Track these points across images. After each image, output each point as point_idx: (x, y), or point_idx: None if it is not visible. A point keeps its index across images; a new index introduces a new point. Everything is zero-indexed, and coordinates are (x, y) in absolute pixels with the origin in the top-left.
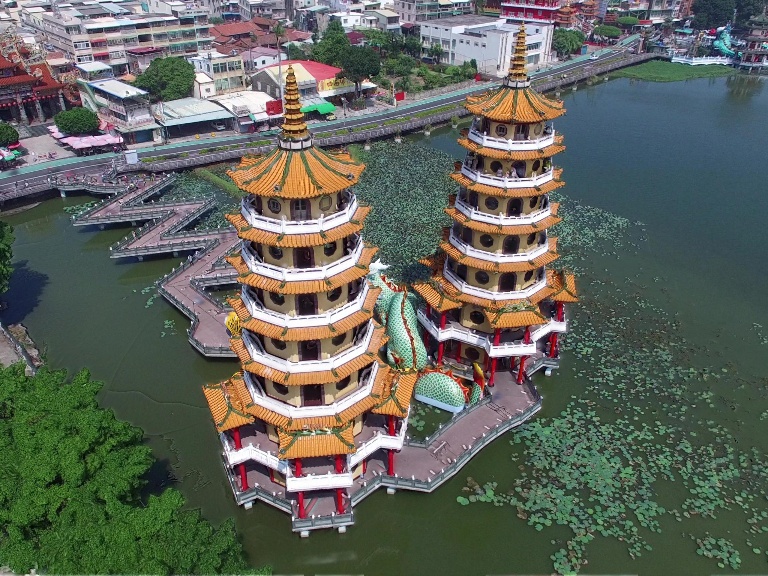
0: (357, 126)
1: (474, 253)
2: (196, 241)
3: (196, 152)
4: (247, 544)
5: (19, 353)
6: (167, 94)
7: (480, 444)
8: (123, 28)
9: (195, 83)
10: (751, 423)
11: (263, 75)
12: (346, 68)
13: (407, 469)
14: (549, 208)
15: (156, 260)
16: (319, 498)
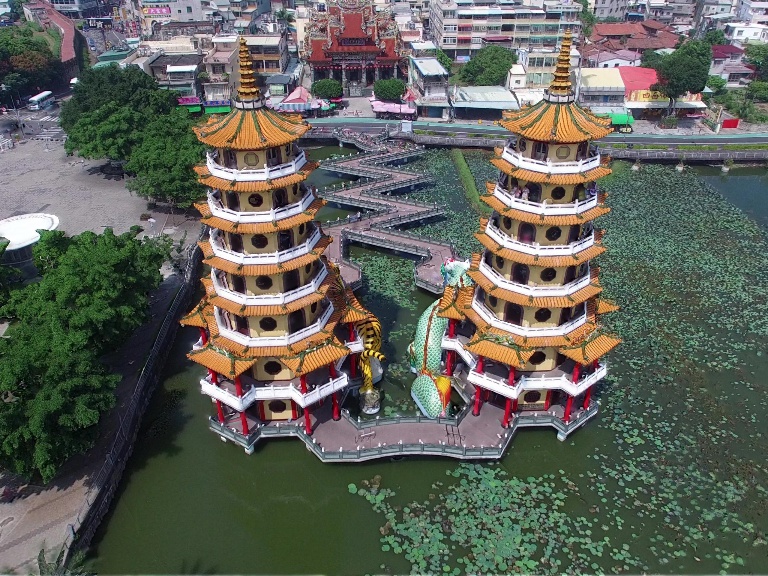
0: (645, 144)
1: (485, 269)
2: (379, 203)
3: (466, 134)
4: (191, 423)
5: (197, 239)
6: (480, 79)
7: (396, 449)
8: (492, 17)
9: (508, 73)
10: None
11: (573, 75)
12: (661, 80)
13: (327, 435)
14: (571, 246)
15: (349, 210)
16: (247, 418)
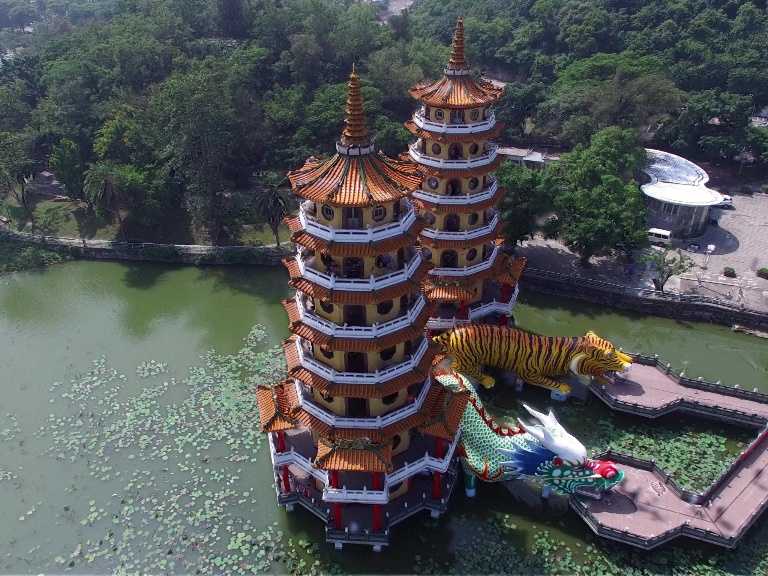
0: None
1: None
2: None
3: None
4: None
5: None
6: None
7: None
8: None
9: None
10: (57, 493)
11: None
12: None
13: None
14: (299, 291)
15: None
16: None
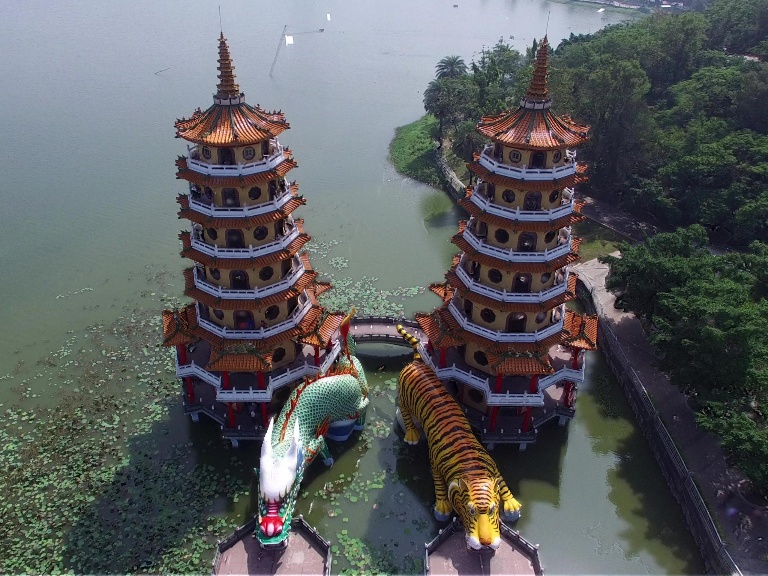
0: None
1: None
2: None
3: None
4: None
5: None
6: None
7: None
8: None
9: None
10: None
11: None
12: None
13: None
14: None
15: None
16: None
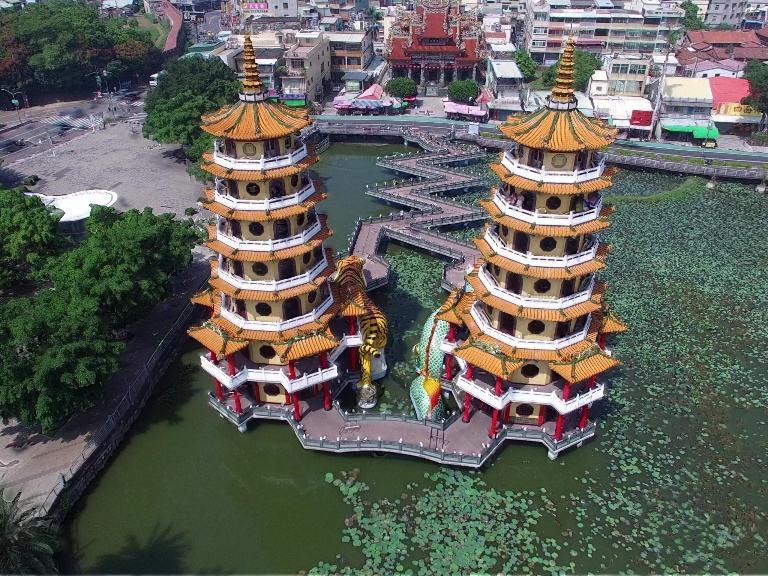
0: (727, 160)
1: (482, 275)
2: (425, 203)
3: None
4: (197, 397)
5: None
6: None
7: (375, 445)
8: (586, 20)
9: (590, 79)
10: None
11: (657, 83)
12: (754, 93)
13: (314, 423)
14: (565, 259)
15: (397, 208)
16: (245, 397)
